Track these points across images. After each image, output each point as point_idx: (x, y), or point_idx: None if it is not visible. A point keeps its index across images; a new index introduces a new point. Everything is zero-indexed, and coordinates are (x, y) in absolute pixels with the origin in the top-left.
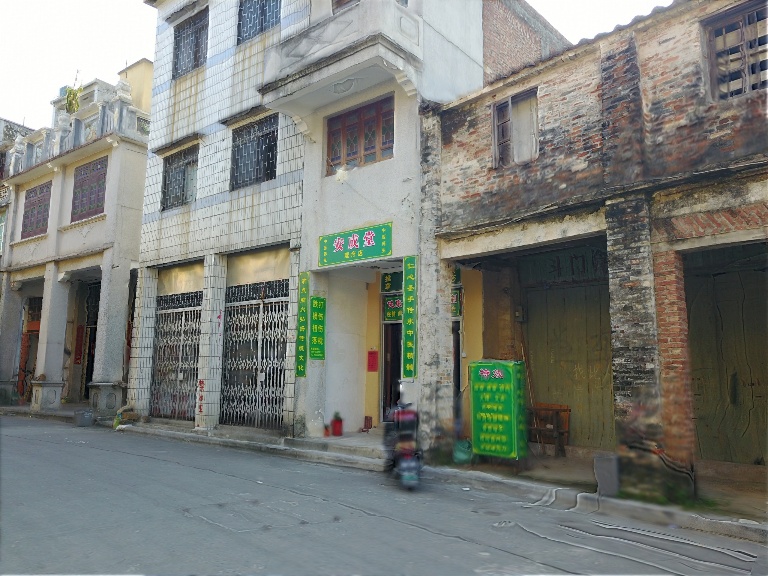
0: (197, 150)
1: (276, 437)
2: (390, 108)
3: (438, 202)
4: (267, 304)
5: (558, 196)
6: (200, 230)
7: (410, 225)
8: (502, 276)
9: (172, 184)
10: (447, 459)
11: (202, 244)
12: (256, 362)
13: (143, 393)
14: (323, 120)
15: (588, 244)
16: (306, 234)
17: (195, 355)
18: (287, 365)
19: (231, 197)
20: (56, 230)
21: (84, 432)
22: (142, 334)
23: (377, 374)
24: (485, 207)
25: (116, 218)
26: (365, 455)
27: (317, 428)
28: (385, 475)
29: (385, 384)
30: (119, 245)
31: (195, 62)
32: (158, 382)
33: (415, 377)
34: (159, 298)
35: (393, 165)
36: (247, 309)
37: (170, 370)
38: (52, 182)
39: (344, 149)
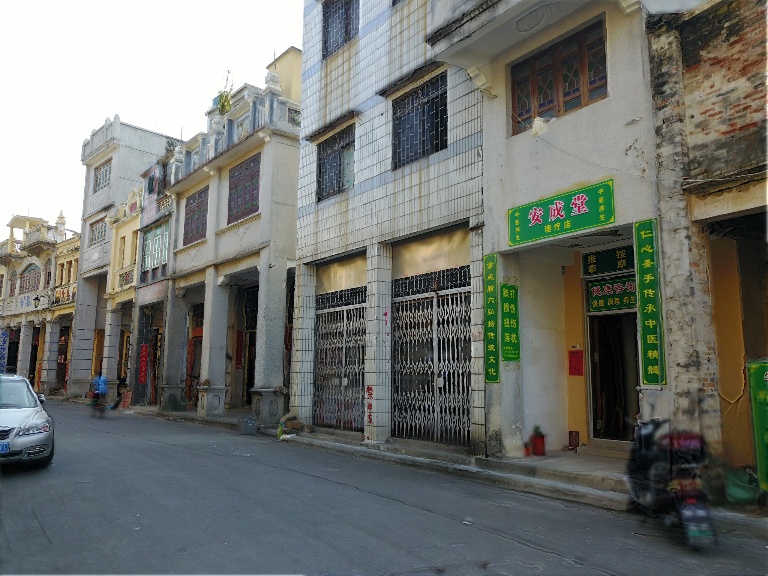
0: (353, 130)
1: (462, 455)
2: (598, 36)
3: (683, 145)
4: (442, 297)
5: None
6: (360, 218)
7: (641, 180)
8: (764, 245)
9: (327, 172)
10: (719, 497)
11: (363, 233)
12: (432, 365)
13: (306, 400)
14: (505, 68)
15: None
16: (490, 208)
17: (360, 358)
18: (473, 368)
19: (394, 177)
20: (214, 234)
21: (248, 442)
22: (302, 336)
23: (583, 378)
24: (767, 140)
25: (271, 215)
26: (591, 485)
27: (515, 446)
28: (629, 516)
29: (594, 391)
30: (275, 243)
31: (346, 36)
32: (321, 388)
33: (663, 383)
34: (318, 297)
35: (609, 106)
36: (418, 304)
37: (333, 375)
38: (209, 186)
39: (535, 99)
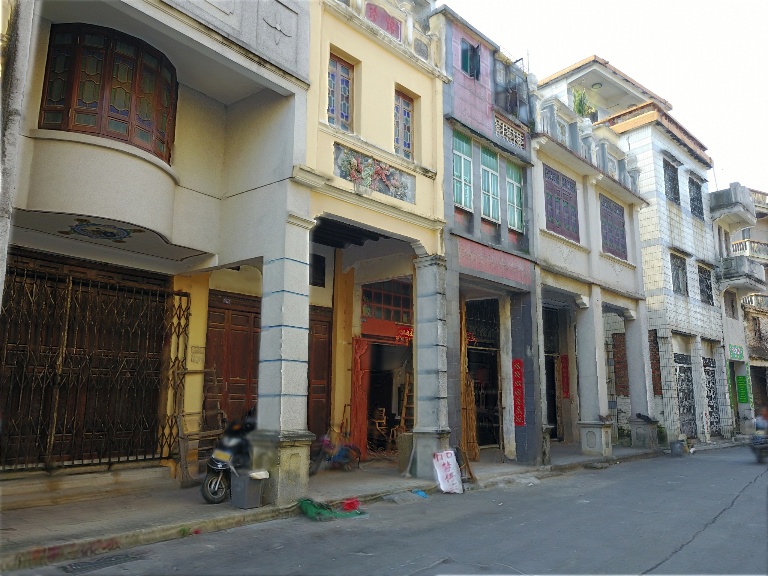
0: None
1: None
2: None
3: None
4: None
5: (766, 354)
6: None
7: (746, 350)
8: None
9: None
10: None
11: None
12: None
13: None
14: None
15: (762, 368)
16: (725, 341)
17: None
18: None
19: (702, 305)
20: None
21: None
22: None
23: None
24: None
25: None
26: None
27: None
28: None
29: None
30: None
31: None
32: None
33: None
34: None
35: None
36: None
37: None
38: None
39: None
